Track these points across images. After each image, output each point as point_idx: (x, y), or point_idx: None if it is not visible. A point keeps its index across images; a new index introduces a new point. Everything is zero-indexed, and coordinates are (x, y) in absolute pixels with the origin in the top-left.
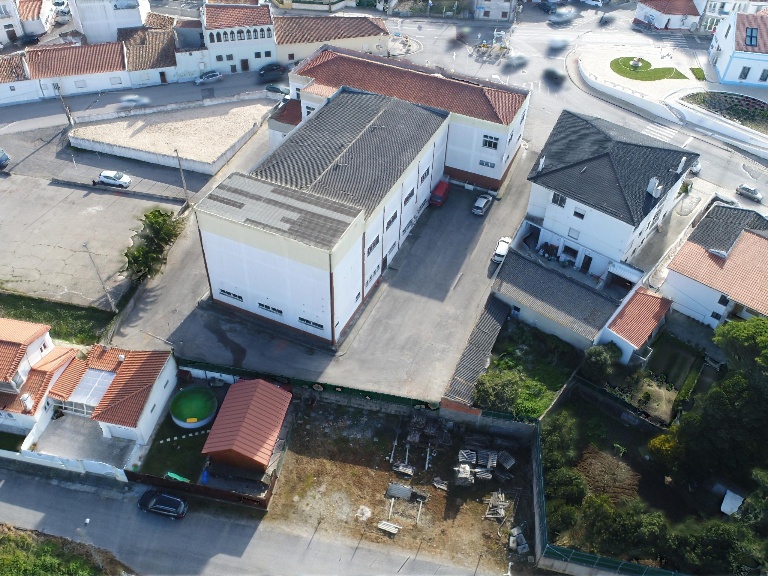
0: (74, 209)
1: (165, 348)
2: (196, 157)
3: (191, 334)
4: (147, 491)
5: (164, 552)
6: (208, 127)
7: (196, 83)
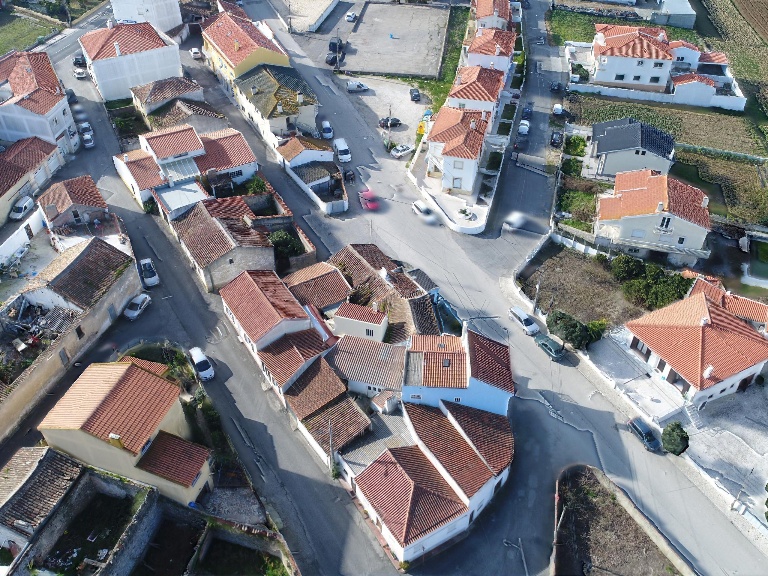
0: (378, 23)
1: (462, 4)
2: (327, 1)
3: (452, 1)
4: (523, 6)
5: (540, 6)
6: (294, 1)
7: (242, 4)
